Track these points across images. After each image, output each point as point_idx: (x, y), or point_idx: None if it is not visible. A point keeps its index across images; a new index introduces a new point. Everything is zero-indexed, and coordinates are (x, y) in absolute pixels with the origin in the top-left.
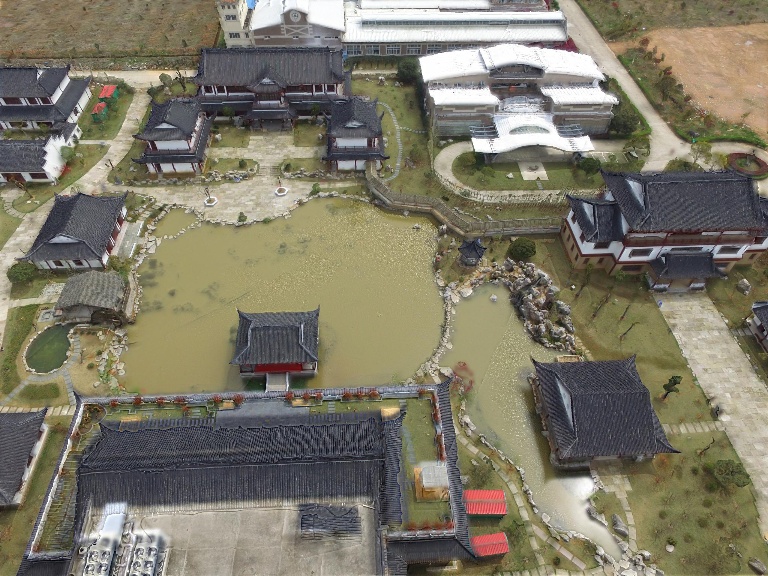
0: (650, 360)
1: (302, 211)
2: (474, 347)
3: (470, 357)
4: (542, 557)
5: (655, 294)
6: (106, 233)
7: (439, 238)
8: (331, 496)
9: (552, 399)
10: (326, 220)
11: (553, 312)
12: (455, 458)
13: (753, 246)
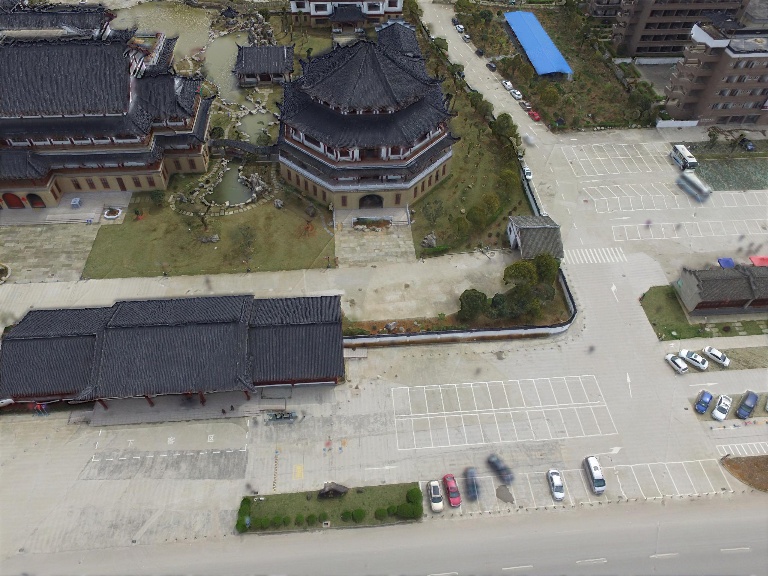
0: (314, 56)
1: (140, 7)
2: (219, 54)
3: (216, 59)
4: (214, 109)
5: (334, 35)
6: (12, 5)
7: (219, 16)
8: (81, 26)
9: (240, 57)
10: (154, 10)
11: (267, 38)
12: (167, 57)
13: (392, 8)
